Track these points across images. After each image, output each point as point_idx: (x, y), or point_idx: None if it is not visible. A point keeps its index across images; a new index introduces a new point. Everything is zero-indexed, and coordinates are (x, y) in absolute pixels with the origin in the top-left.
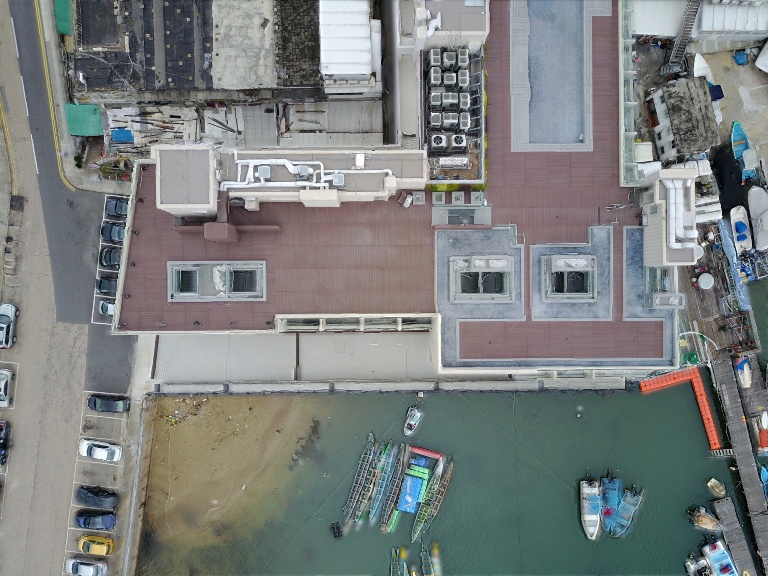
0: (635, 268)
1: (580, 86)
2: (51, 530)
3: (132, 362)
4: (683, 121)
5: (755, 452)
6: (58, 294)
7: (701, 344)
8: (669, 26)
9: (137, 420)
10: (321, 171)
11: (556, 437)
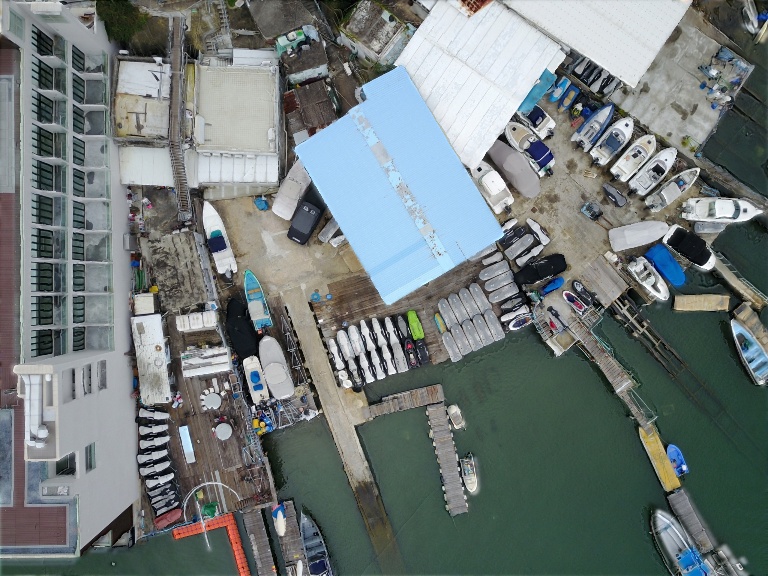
0: None
1: None
2: None
3: None
4: (168, 277)
5: None
6: None
7: (223, 495)
8: (168, 177)
9: None
10: None
11: None
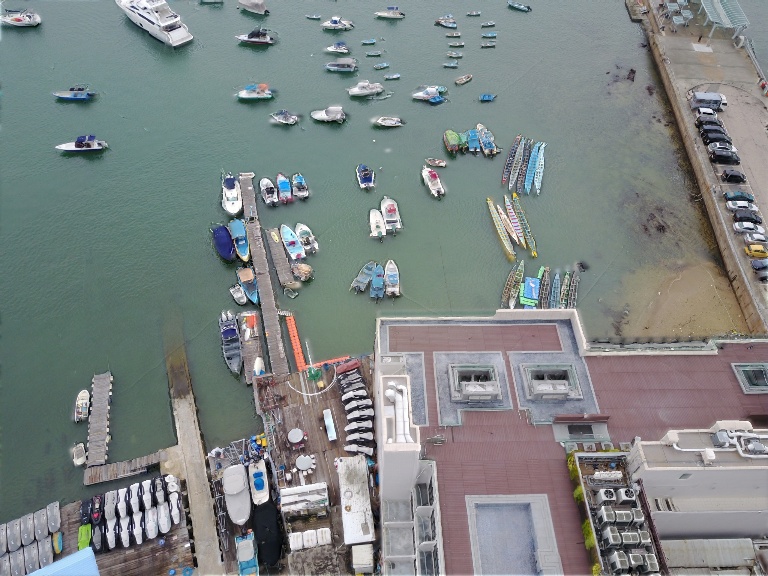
0: (415, 392)
1: (482, 572)
2: None
3: None
4: None
5: (258, 314)
6: None
7: (302, 385)
8: None
9: None
10: (740, 448)
11: None
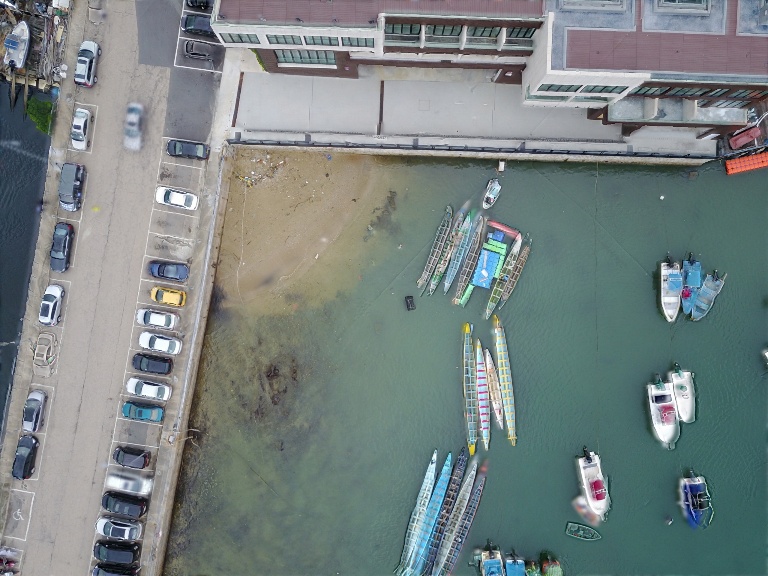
0: None
1: None
2: (123, 280)
3: (213, 109)
4: None
5: None
6: (141, 34)
7: None
8: None
9: (216, 169)
10: None
11: (637, 220)
